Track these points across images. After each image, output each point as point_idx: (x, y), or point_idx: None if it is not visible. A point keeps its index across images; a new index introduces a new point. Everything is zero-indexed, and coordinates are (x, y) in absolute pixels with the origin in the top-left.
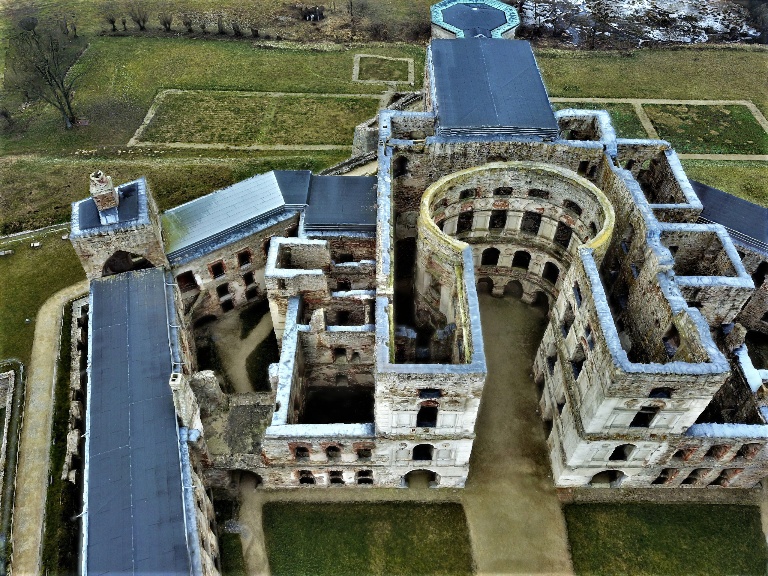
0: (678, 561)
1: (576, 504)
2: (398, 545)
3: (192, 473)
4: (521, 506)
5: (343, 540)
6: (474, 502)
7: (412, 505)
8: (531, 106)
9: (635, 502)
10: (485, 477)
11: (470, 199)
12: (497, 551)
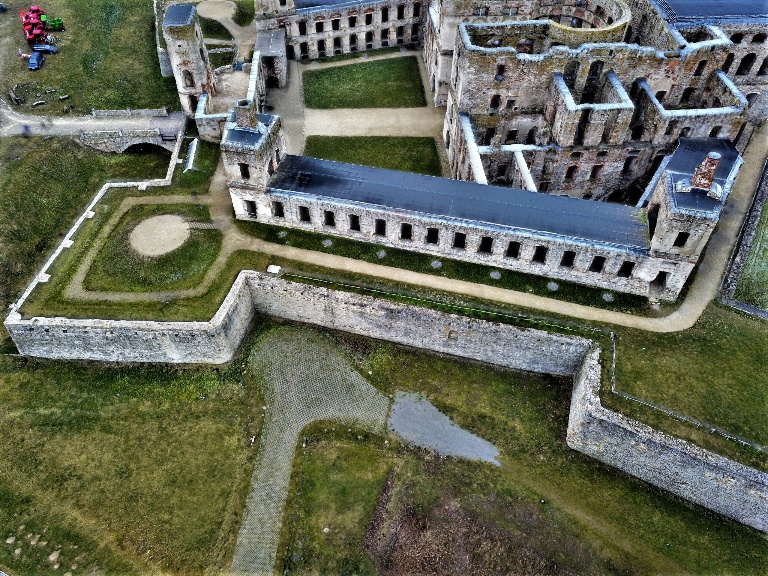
0: (407, 171)
1: (434, 142)
2: (402, 88)
3: (410, 1)
4: (429, 124)
5: (402, 75)
6: (428, 110)
7: (423, 93)
8: (701, 7)
9: (440, 163)
10: (443, 114)
11: (600, 17)
12: (403, 115)
